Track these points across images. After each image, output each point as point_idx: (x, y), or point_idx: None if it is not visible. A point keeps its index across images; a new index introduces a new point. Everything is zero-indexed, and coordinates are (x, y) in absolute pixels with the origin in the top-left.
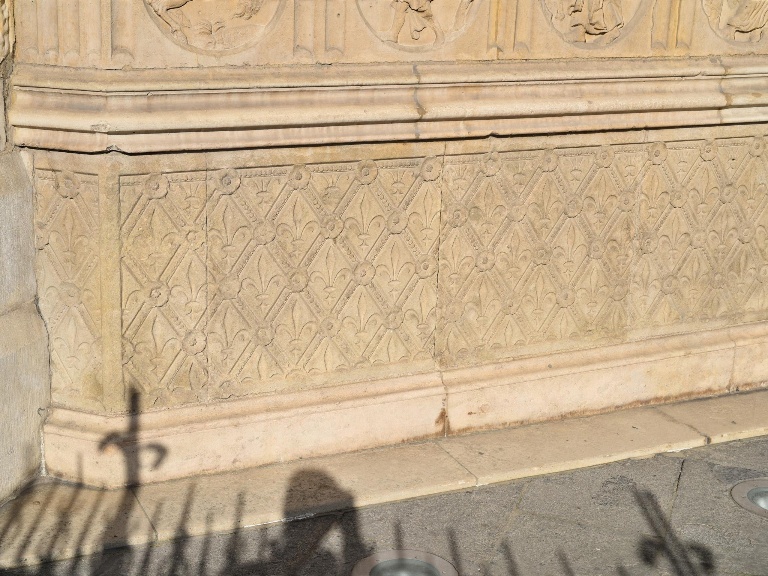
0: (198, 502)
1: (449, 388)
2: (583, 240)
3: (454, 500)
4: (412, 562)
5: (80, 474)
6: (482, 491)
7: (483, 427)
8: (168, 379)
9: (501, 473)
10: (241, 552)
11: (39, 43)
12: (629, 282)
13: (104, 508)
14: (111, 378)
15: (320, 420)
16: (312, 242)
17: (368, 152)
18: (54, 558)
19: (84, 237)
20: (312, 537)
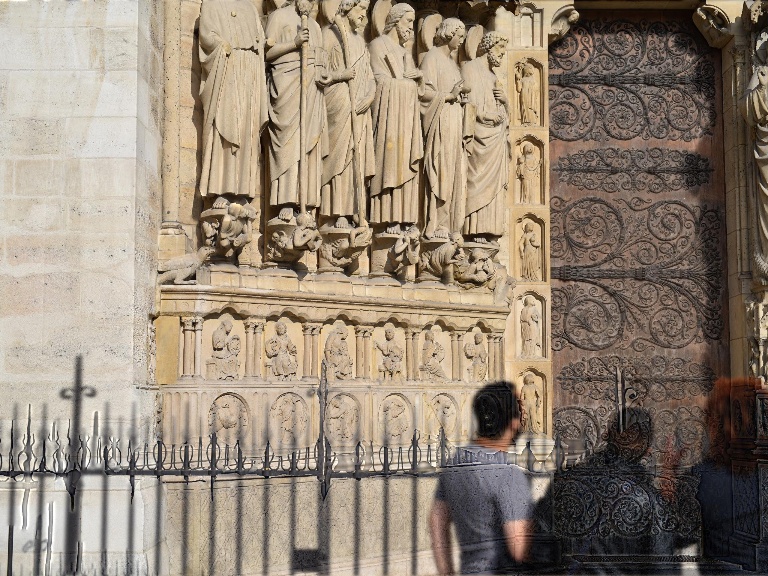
0: None
1: (306, 574)
2: (347, 516)
3: None
4: None
5: None
6: None
7: None
8: (213, 567)
9: None
10: None
11: None
12: (365, 533)
13: None
14: (196, 566)
15: None
16: (259, 515)
17: (276, 481)
18: None
19: (187, 513)
20: None
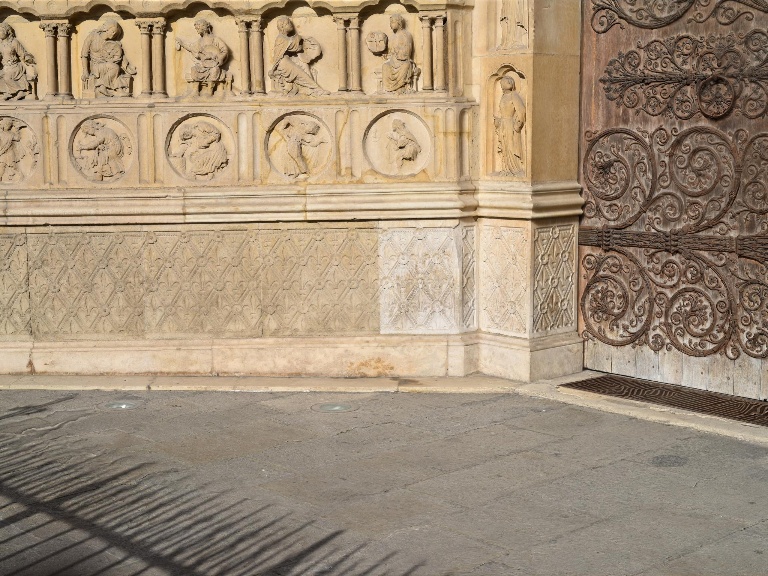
0: None
1: (33, 349)
2: (111, 281)
3: None
4: None
5: None
6: (7, 390)
7: (54, 373)
8: None
9: (23, 385)
10: None
11: None
12: (144, 306)
13: None
14: None
15: None
16: None
17: None
18: None
19: None
20: None
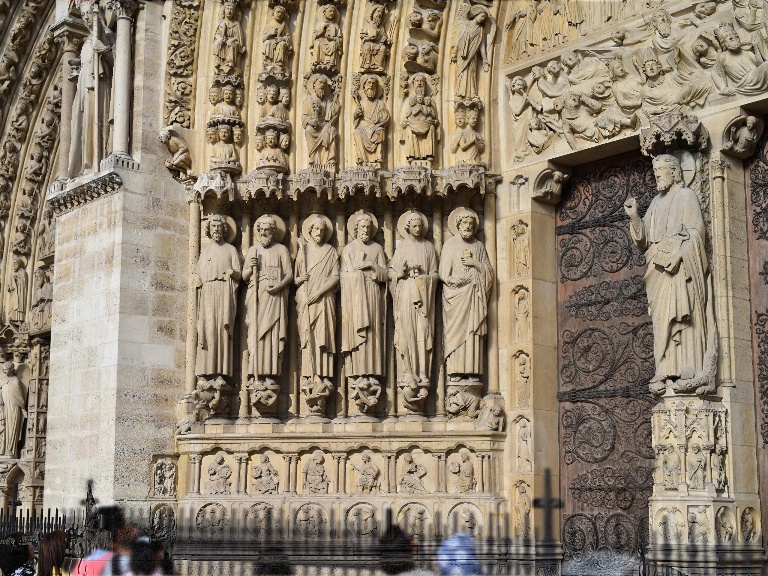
0: None
1: None
2: None
3: None
4: None
5: None
6: None
7: None
8: None
9: None
10: None
11: (180, 536)
12: None
13: None
14: None
15: None
16: None
17: (248, 563)
18: None
19: None
20: None
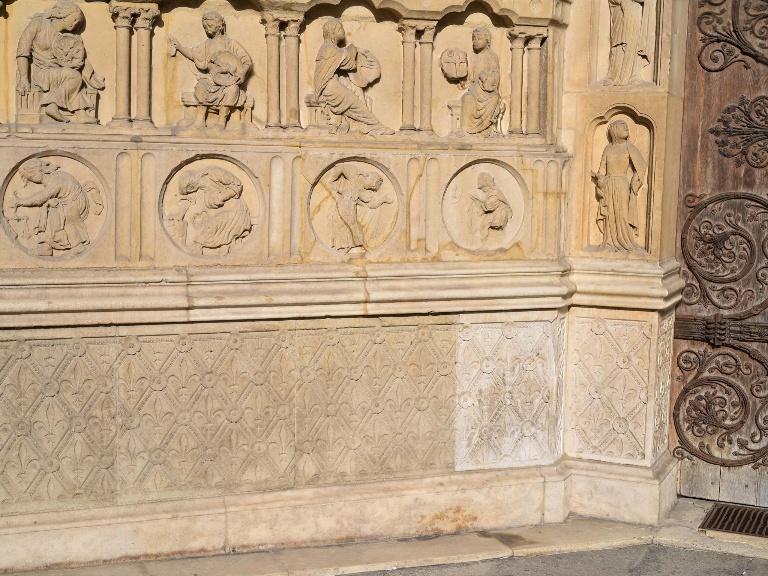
0: None
1: None
2: (63, 416)
3: None
4: None
5: None
6: None
7: None
8: None
9: None
10: None
11: None
12: (115, 453)
13: None
14: None
15: None
16: None
17: None
18: None
19: None
20: None
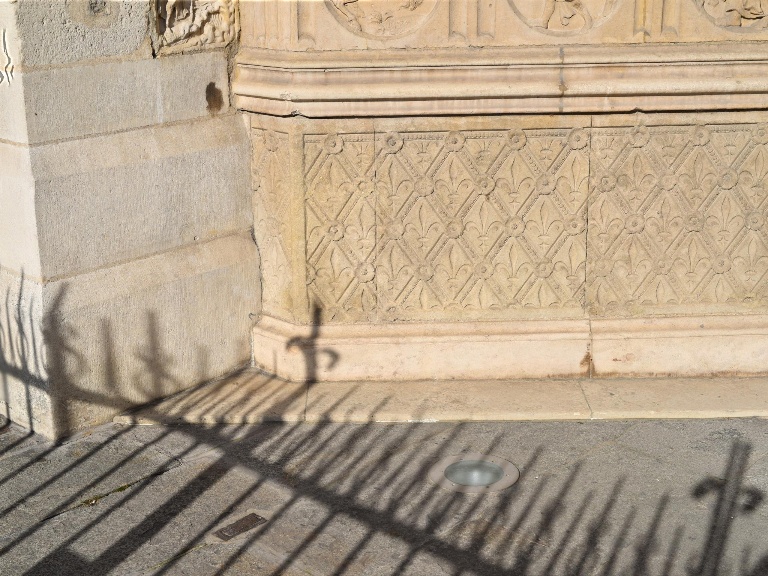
0: (351, 399)
1: (594, 335)
2: (739, 211)
3: (562, 427)
4: (487, 464)
5: (275, 368)
6: (593, 423)
7: (629, 374)
8: (344, 300)
9: (617, 411)
10: (359, 437)
11: (254, 31)
12: None
13: (280, 393)
14: (298, 294)
15: (470, 348)
16: (467, 197)
17: (517, 122)
18: (226, 421)
19: (282, 182)
20: (423, 436)
